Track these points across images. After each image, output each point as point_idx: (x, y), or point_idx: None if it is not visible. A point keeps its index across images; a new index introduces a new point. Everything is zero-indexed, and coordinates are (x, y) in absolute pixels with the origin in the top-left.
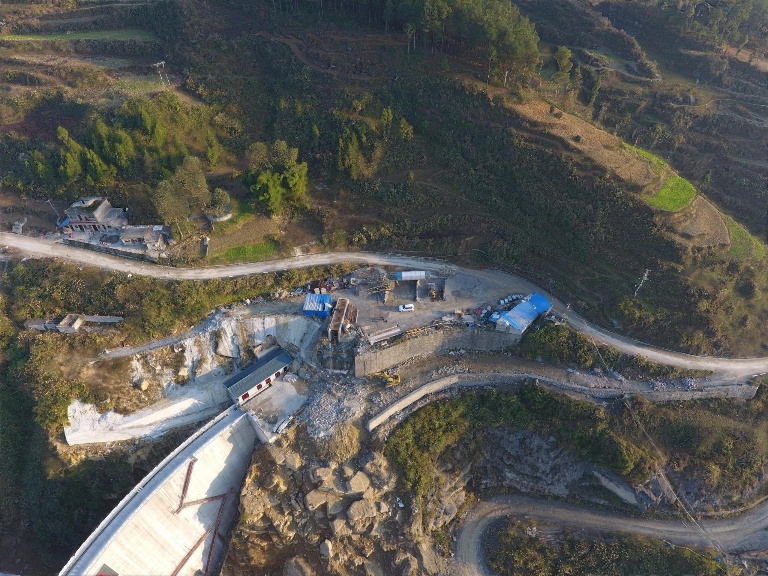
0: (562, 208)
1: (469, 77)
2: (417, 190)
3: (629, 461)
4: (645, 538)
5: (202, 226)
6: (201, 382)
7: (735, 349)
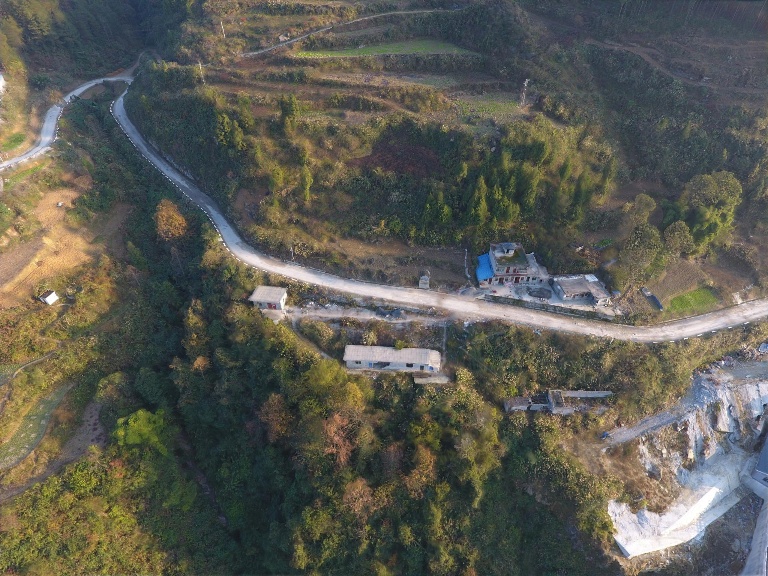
0: None
1: None
2: None
3: None
4: None
5: None
6: (709, 465)
7: None
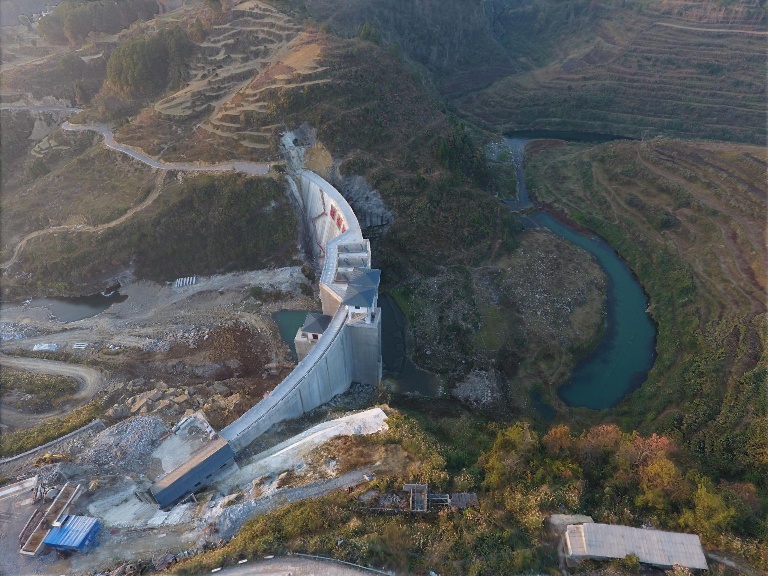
0: None
1: None
2: None
3: None
4: None
5: None
6: None
7: None
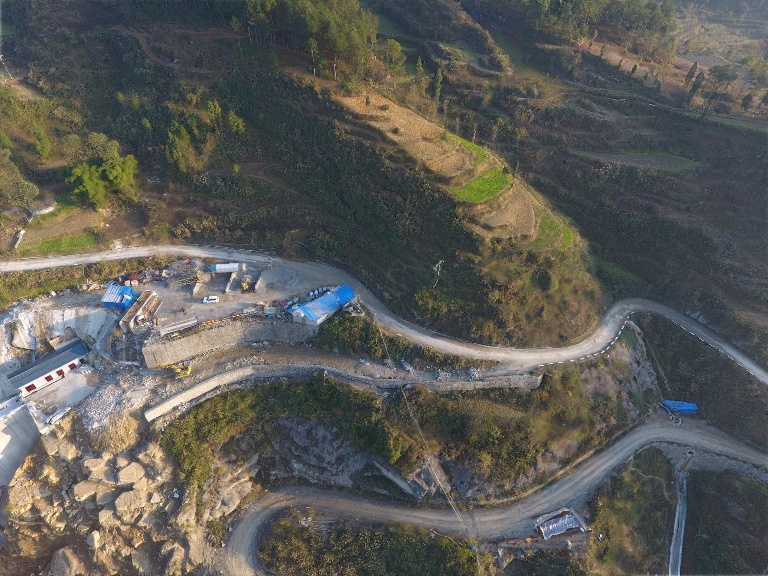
0: (375, 200)
1: (301, 70)
2: (246, 183)
3: (392, 450)
4: (412, 527)
5: (20, 219)
6: None
7: (528, 339)
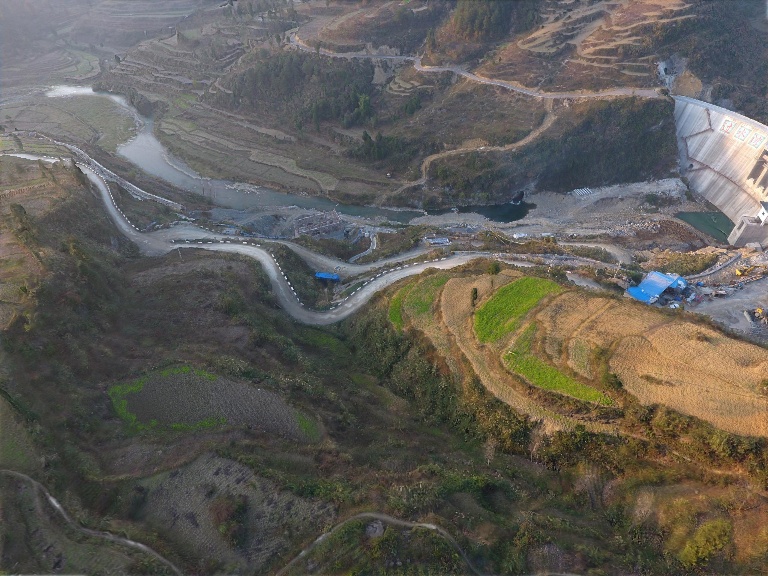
0: None
1: None
2: None
3: None
4: None
5: None
6: None
7: None
